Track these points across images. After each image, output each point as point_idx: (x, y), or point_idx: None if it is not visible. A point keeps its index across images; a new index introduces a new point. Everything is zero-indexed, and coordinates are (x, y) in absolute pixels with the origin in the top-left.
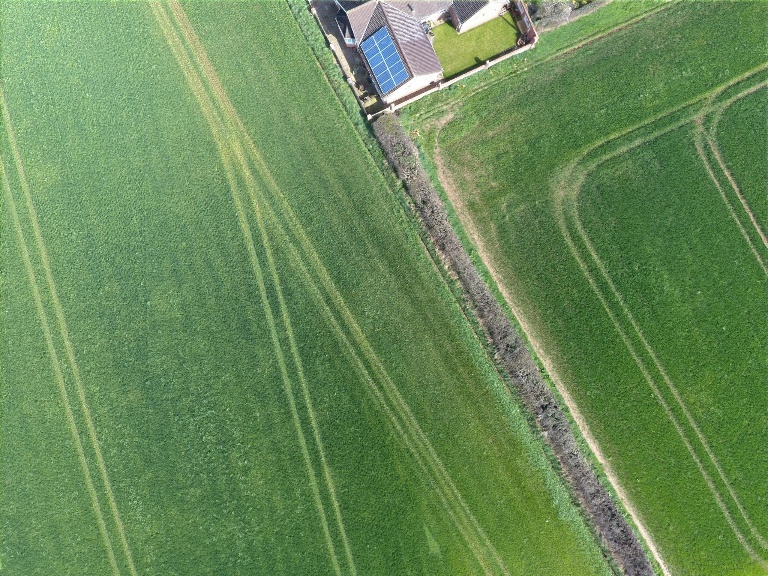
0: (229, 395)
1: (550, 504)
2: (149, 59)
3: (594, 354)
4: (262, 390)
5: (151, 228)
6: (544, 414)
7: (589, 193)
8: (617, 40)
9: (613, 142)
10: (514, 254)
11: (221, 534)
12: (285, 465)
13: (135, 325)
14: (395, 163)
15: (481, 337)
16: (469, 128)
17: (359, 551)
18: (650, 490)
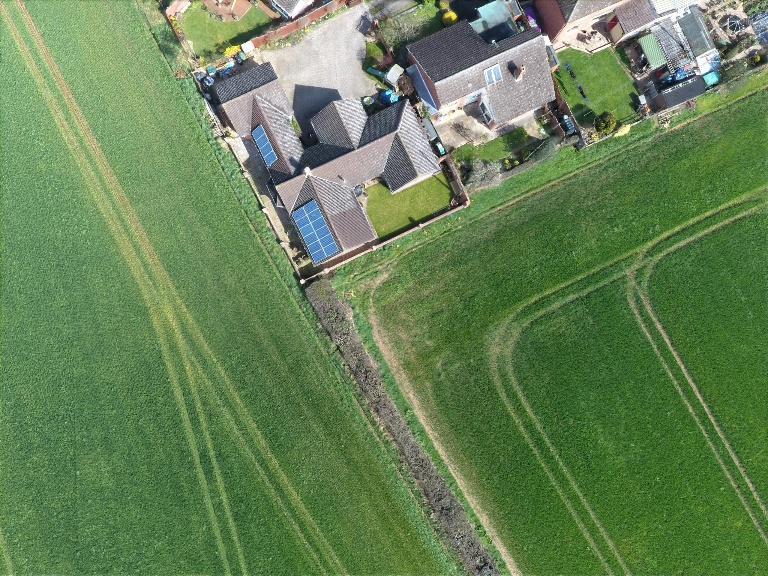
0: (162, 563)
1: None
2: (78, 224)
3: (530, 509)
4: (196, 557)
5: (81, 396)
6: (480, 575)
7: (523, 350)
8: (550, 197)
9: (546, 299)
10: (450, 412)
11: None
12: None
13: (64, 495)
14: (328, 329)
15: (417, 497)
16: (404, 288)
17: None
18: None
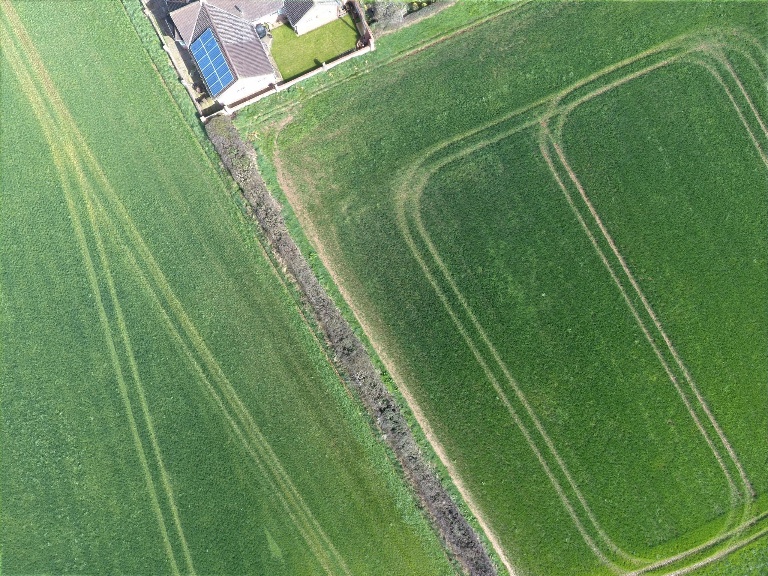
0: (62, 399)
1: (393, 507)
2: None
3: (437, 357)
4: (96, 394)
5: None
6: (382, 417)
7: (431, 195)
8: (460, 42)
9: (455, 144)
10: (355, 257)
11: (56, 539)
12: (121, 469)
13: None
14: (228, 165)
15: (321, 340)
16: (308, 130)
17: (198, 556)
18: (496, 493)
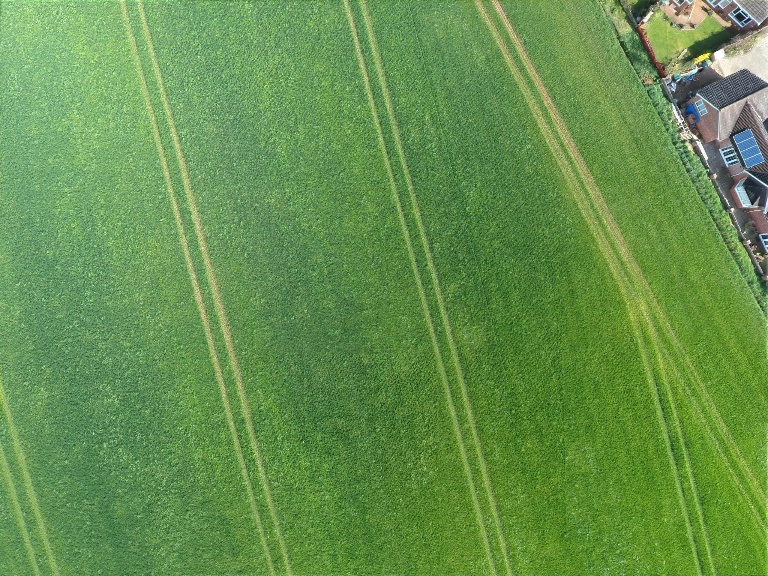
0: (639, 545)
1: None
2: (563, 223)
3: None
4: (668, 539)
5: (568, 386)
6: None
7: None
8: None
9: None
10: None
11: None
12: None
13: (554, 480)
14: None
15: None
16: None
17: None
18: None
